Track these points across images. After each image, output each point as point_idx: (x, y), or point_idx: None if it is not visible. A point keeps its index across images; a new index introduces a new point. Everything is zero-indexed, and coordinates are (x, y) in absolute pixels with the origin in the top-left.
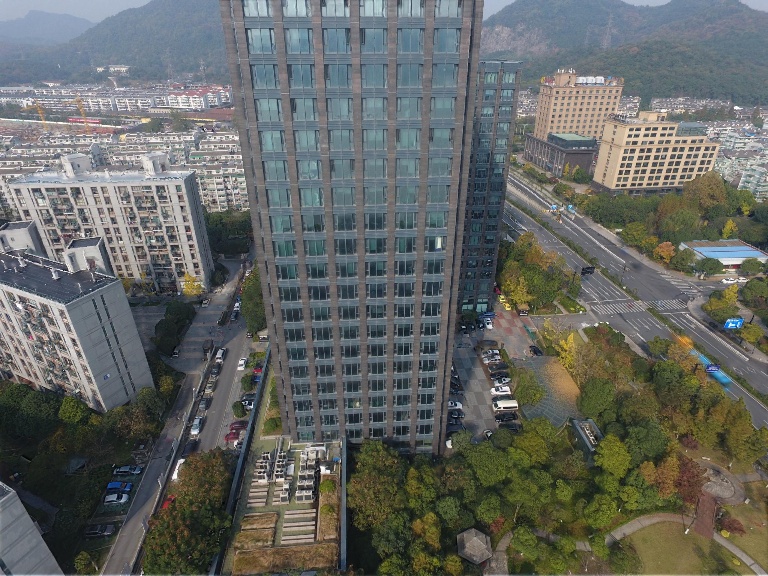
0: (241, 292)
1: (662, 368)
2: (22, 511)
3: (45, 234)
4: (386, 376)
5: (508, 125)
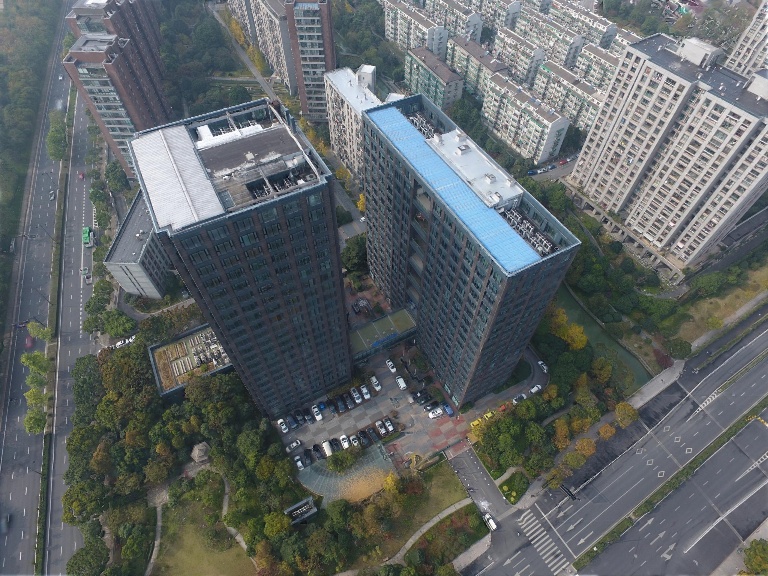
0: None
1: (401, 572)
2: (142, 270)
3: (332, 113)
4: None
5: None
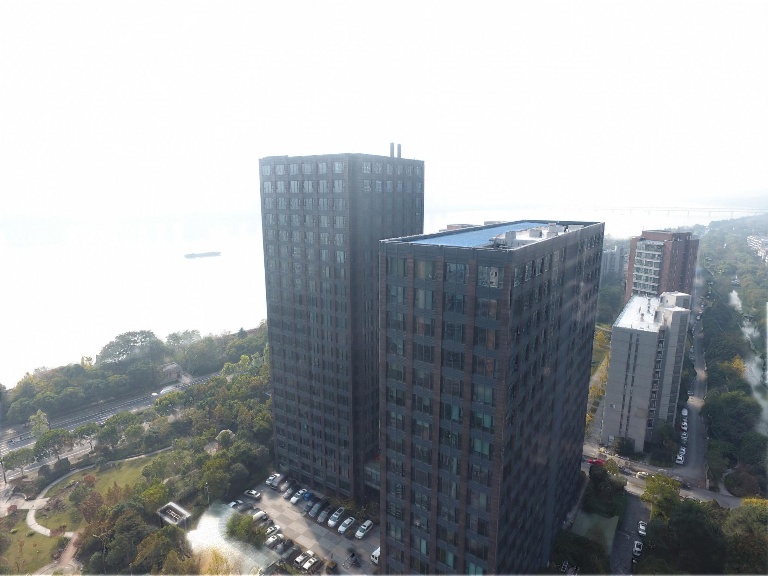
0: (590, 460)
1: None
2: None
3: None
4: None
5: None
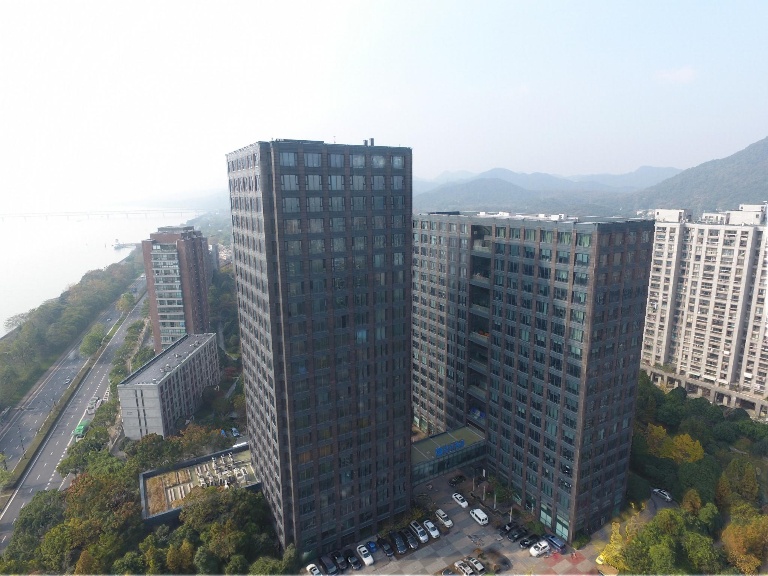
0: None
1: None
2: (158, 396)
3: None
4: None
5: None
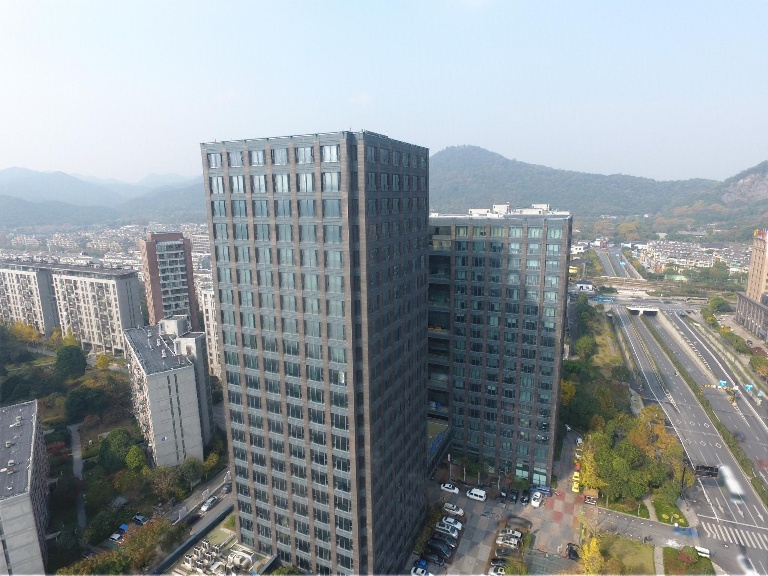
0: None
1: None
2: (30, 510)
3: (214, 328)
4: (307, 502)
5: (558, 279)
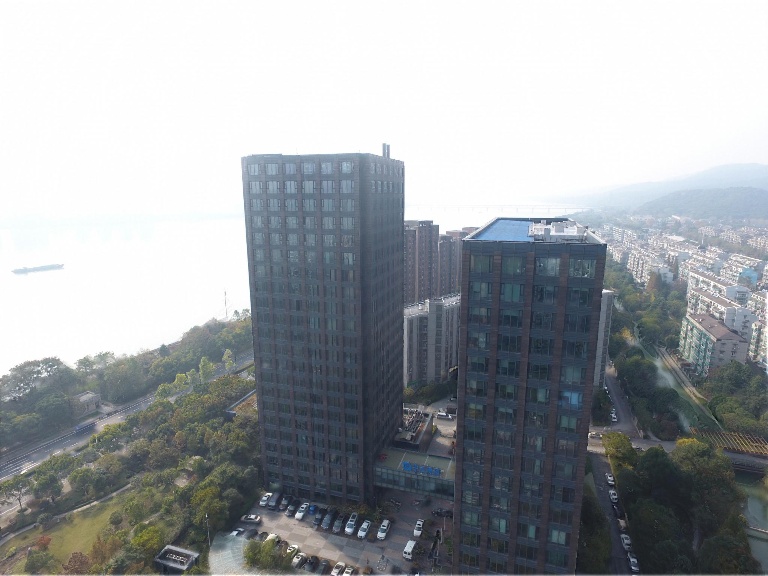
0: None
1: None
2: None
3: None
4: None
5: None
